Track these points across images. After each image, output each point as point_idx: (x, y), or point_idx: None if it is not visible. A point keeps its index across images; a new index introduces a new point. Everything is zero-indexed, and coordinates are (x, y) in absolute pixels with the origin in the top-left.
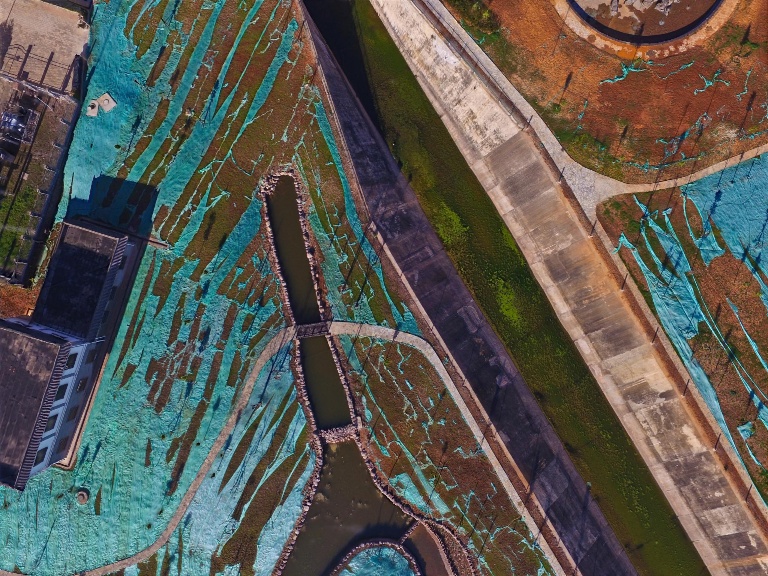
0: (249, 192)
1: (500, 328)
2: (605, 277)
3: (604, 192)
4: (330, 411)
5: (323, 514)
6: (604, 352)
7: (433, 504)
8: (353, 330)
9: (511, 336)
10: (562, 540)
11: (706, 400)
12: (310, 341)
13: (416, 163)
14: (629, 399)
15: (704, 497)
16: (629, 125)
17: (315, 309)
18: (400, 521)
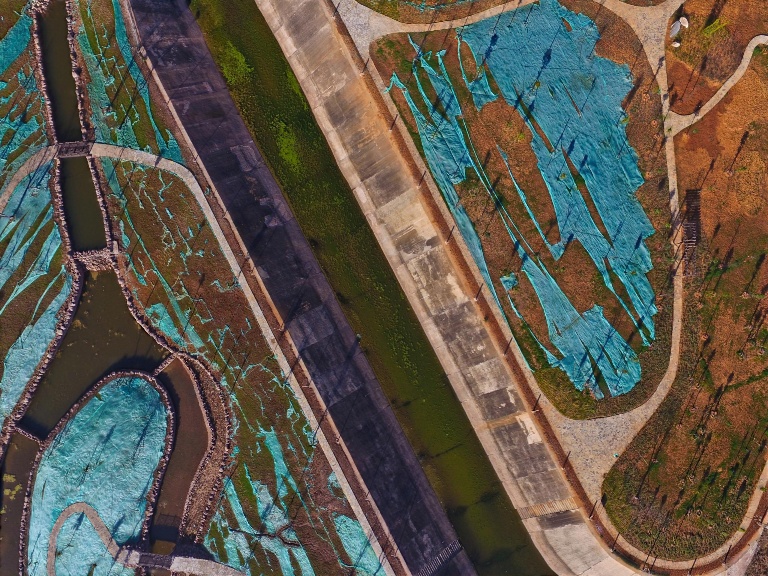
0: (19, 7)
1: (278, 172)
2: (375, 117)
3: (378, 30)
4: (88, 234)
5: (80, 342)
6: (378, 199)
7: (188, 337)
8: (115, 153)
9: (289, 181)
10: (314, 381)
11: (470, 248)
12: (71, 161)
13: (205, 1)
14: (401, 249)
15: (468, 352)
16: None
17: (79, 130)
18: (157, 355)
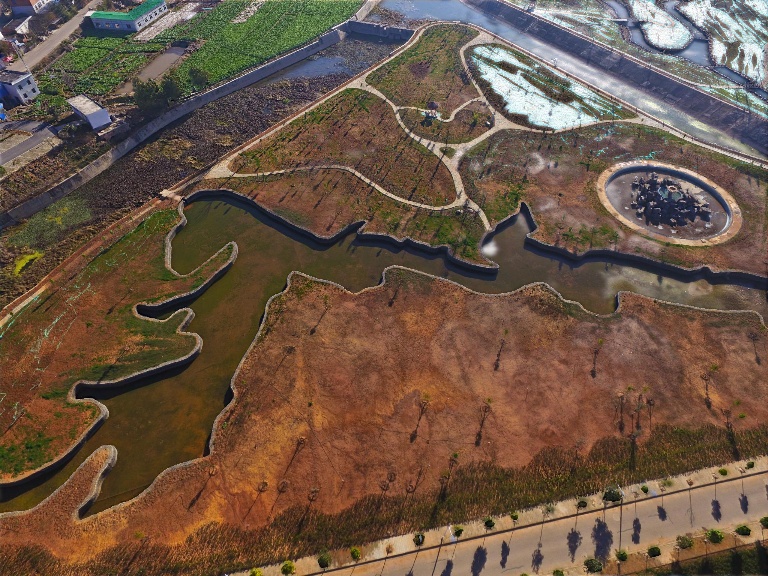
0: None
1: None
2: None
3: None
4: None
5: None
6: None
7: None
8: None
9: None
10: None
11: None
12: None
13: None
14: None
15: None
16: (638, 138)
17: None
18: None
